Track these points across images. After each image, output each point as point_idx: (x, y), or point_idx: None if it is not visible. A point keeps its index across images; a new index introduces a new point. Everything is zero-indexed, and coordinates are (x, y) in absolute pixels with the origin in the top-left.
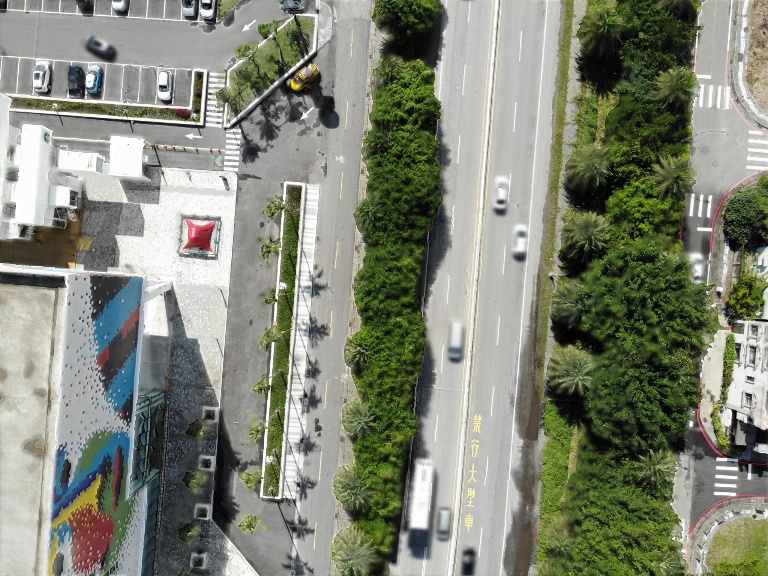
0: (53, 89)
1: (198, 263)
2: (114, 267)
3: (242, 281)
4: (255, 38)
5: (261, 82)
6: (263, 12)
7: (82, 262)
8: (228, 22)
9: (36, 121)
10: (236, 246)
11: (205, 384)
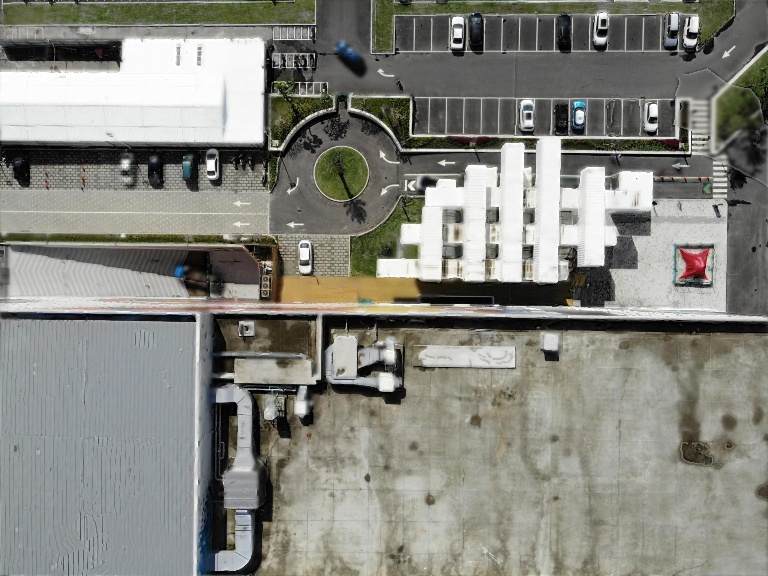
0: (535, 127)
1: (693, 291)
2: (611, 301)
3: (738, 307)
4: (736, 64)
5: None
6: (742, 38)
7: (578, 298)
8: (708, 50)
9: None
10: (730, 272)
11: None
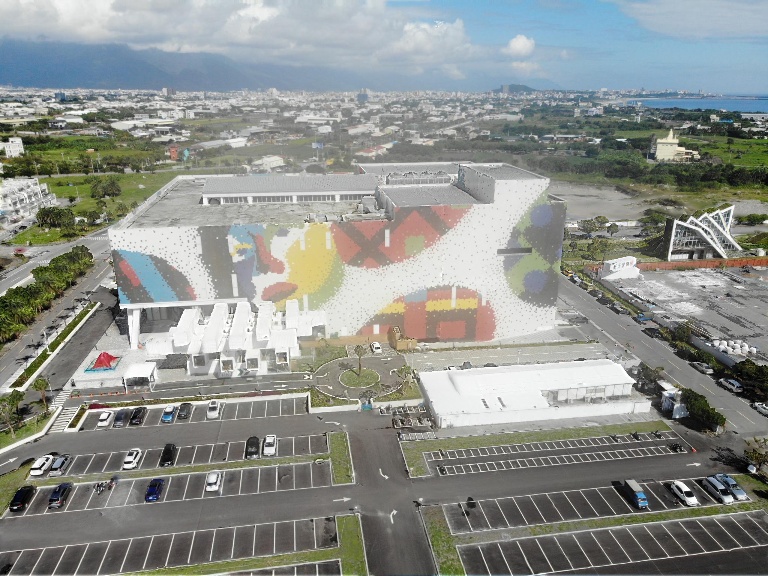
0: None
1: None
2: None
3: None
4: (7, 455)
5: (15, 429)
6: None
7: None
8: None
9: (221, 391)
10: None
11: (121, 324)
